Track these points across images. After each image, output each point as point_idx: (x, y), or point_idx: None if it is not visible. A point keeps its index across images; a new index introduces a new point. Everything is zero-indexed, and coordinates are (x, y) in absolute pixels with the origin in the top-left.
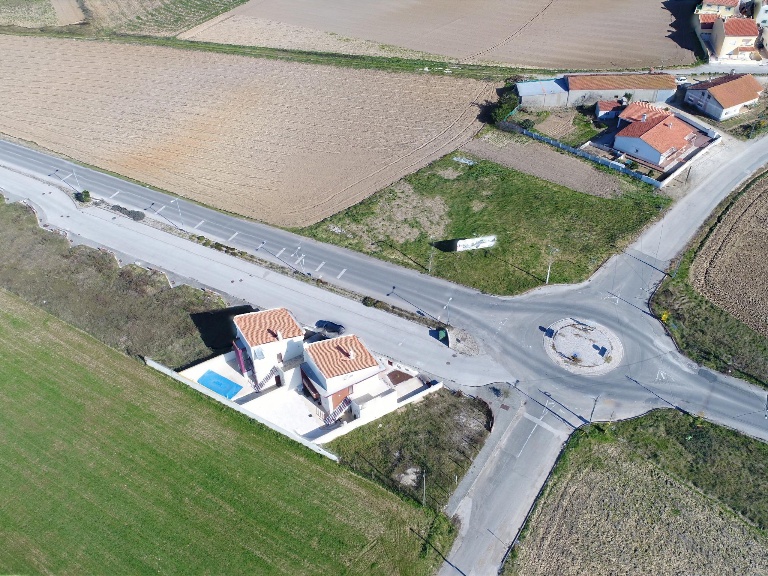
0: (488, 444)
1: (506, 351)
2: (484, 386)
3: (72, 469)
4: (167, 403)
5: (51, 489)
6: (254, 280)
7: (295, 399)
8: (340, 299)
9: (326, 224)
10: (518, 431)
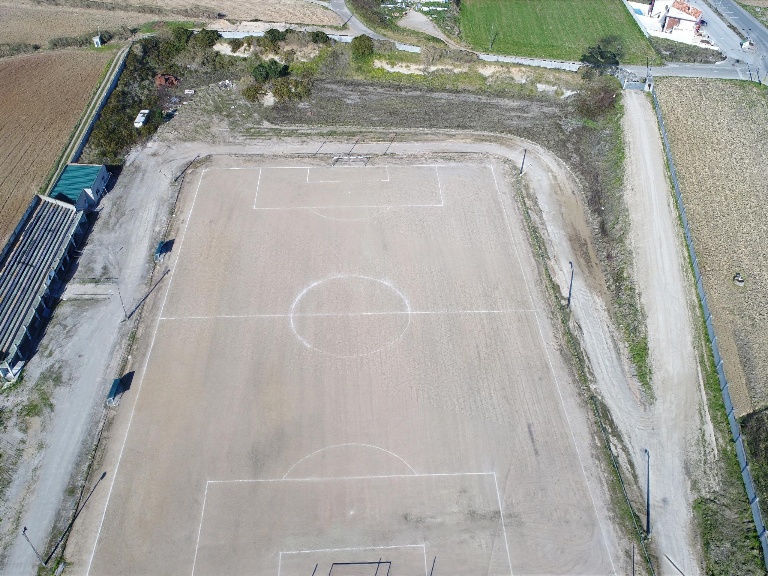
0: (709, 64)
1: (764, 59)
2: (736, 58)
3: (568, 1)
4: (614, 7)
5: (557, 1)
6: (694, 3)
7: (658, 26)
8: (720, 21)
9: (756, 7)
10: (727, 69)
